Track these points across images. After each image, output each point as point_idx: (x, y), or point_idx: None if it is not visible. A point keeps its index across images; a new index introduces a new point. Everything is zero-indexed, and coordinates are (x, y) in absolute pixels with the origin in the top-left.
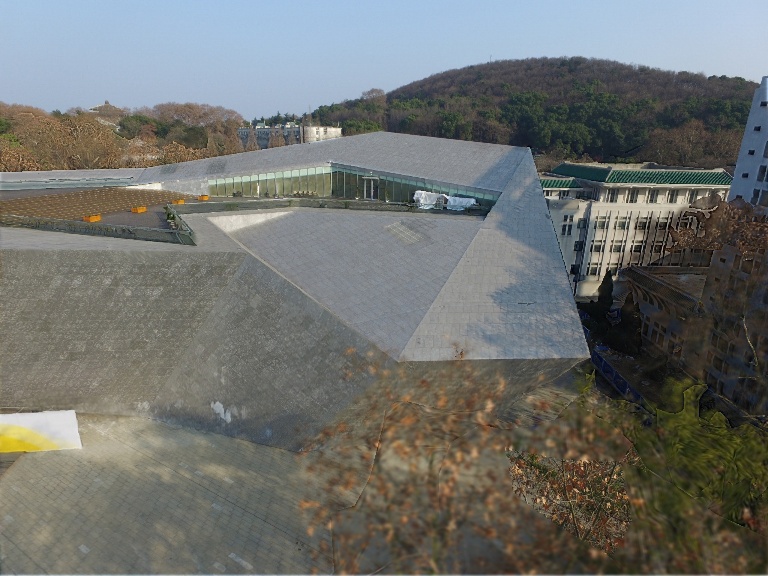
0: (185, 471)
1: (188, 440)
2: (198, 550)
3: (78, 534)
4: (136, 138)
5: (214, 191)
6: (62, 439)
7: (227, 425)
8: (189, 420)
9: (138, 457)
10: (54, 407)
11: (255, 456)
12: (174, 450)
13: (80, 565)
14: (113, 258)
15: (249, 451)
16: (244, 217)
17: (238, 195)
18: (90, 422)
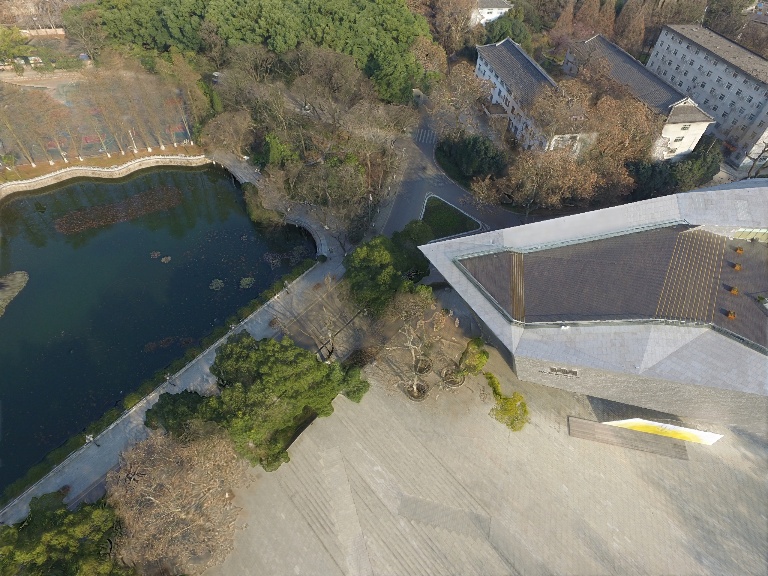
0: None
1: (764, 455)
2: None
3: (755, 507)
4: (606, 100)
5: (738, 235)
6: (706, 441)
7: None
8: (761, 442)
9: (746, 461)
10: (691, 417)
11: None
12: (762, 461)
13: None
14: None
15: None
16: None
17: (757, 241)
18: (698, 423)
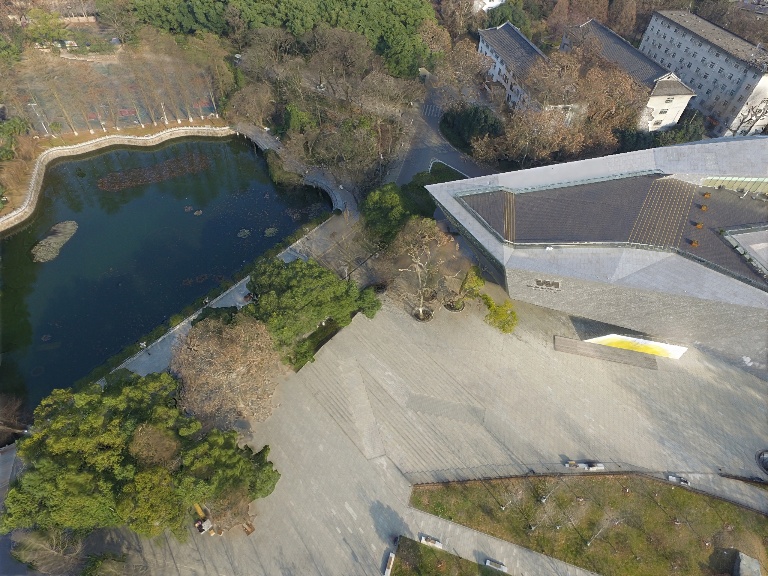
0: (735, 386)
1: (724, 367)
2: (766, 427)
3: (713, 406)
4: (594, 71)
5: (707, 183)
6: (674, 355)
7: (746, 366)
8: (722, 356)
9: (708, 372)
10: None
11: (763, 386)
12: (722, 372)
13: (725, 420)
14: (765, 311)
15: (759, 382)
16: (766, 243)
17: (723, 189)
18: (668, 342)
